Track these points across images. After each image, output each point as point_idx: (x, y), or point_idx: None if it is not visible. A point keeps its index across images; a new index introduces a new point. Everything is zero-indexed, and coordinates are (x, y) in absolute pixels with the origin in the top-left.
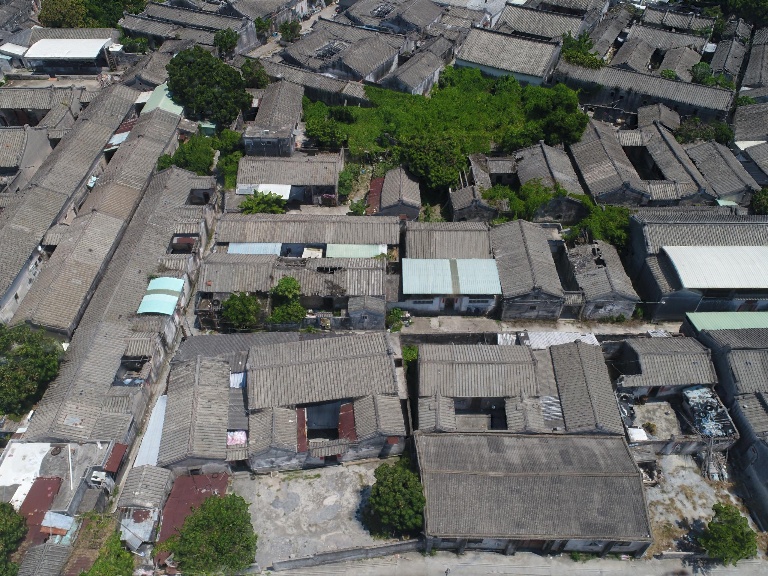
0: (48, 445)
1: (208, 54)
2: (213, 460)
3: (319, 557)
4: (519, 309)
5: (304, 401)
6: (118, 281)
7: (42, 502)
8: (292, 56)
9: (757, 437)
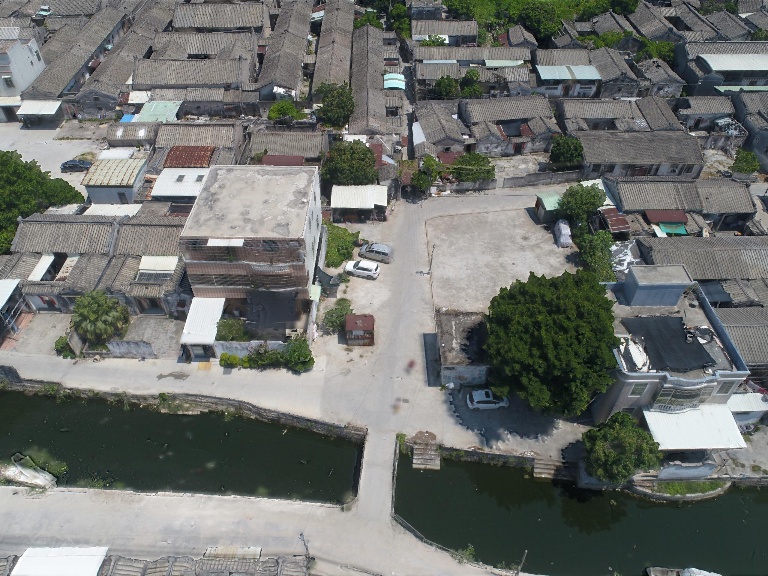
0: (365, 136)
1: None
2: (458, 142)
3: (528, 177)
4: (611, 91)
5: (501, 119)
6: (367, 73)
7: (378, 151)
8: None
9: (758, 129)
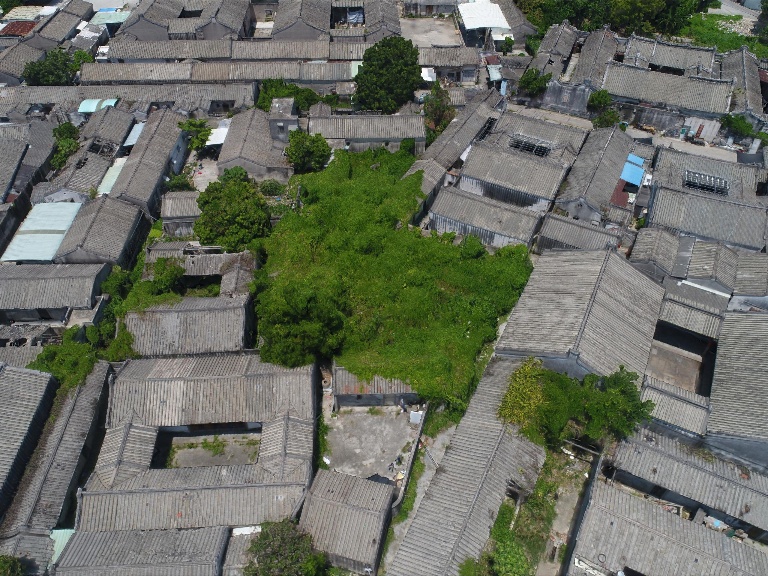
0: None
1: (403, 51)
2: None
3: None
4: None
5: None
6: None
7: None
8: (497, 120)
9: None
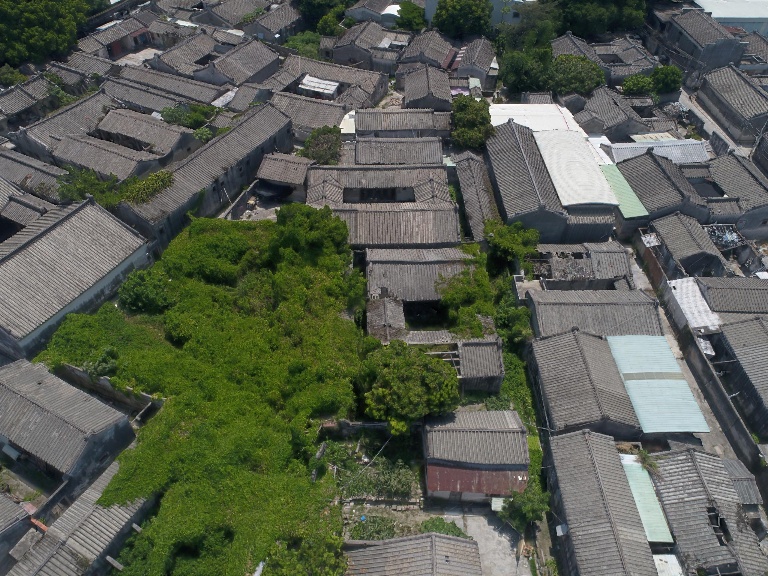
0: None
1: None
2: None
3: None
4: None
5: None
6: None
7: None
8: None
9: None
